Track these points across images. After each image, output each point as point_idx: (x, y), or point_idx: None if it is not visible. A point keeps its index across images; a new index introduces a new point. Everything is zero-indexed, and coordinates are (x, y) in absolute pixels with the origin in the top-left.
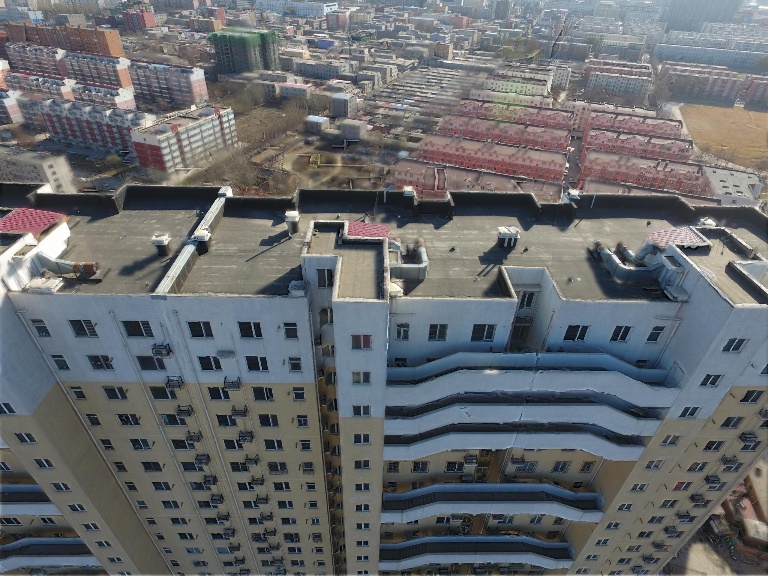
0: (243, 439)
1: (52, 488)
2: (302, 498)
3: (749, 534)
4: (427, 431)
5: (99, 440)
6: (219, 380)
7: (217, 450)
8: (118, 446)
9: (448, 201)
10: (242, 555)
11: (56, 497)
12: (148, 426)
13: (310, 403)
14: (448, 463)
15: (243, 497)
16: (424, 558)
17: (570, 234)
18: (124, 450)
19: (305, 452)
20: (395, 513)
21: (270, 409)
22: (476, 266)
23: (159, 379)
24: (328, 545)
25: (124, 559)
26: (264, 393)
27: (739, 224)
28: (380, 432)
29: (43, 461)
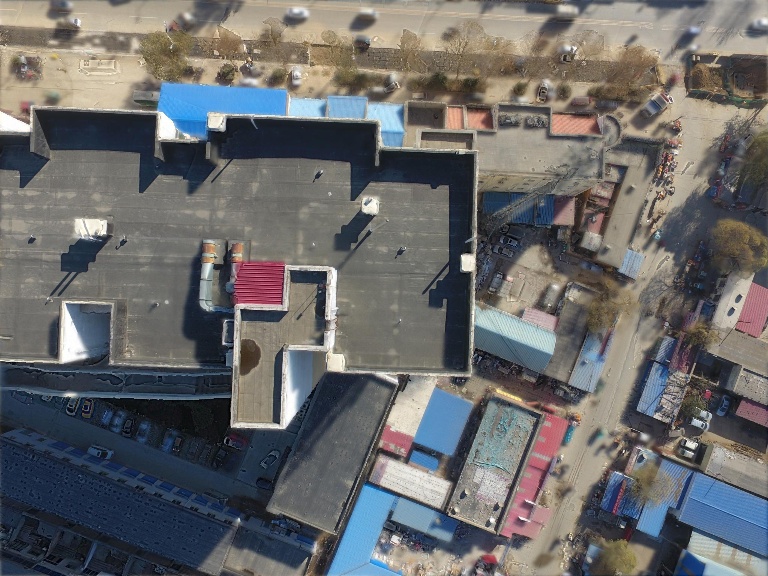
0: None
1: None
2: None
3: (581, 245)
4: None
5: None
6: None
7: None
8: None
9: (28, 137)
10: None
11: None
12: None
13: None
14: None
15: None
16: None
17: (197, 201)
18: None
19: None
20: None
21: None
22: (54, 275)
23: None
24: None
25: None
26: None
27: (449, 174)
28: None
29: None
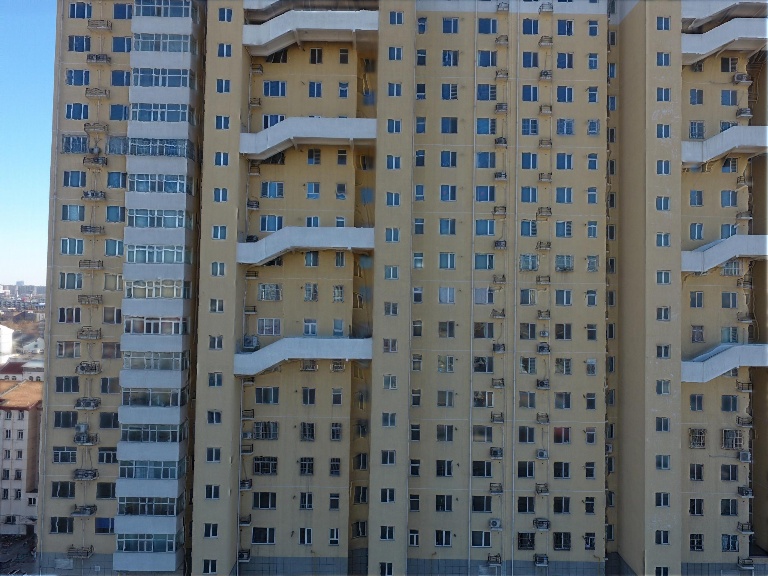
0: (545, 74)
1: (386, 90)
2: (583, 180)
3: None
4: (715, 15)
5: (416, 85)
6: (534, 10)
7: (516, 98)
8: (431, 91)
9: None
10: (502, 306)
11: (384, 105)
12: (464, 65)
13: (602, 38)
14: (722, 125)
15: (524, 179)
16: (731, 241)
17: None
18: (433, 99)
19: (592, 103)
20: (695, 142)
21: (569, 44)
22: None
23: (489, 10)
24: (603, 284)
25: (404, 231)
26: (566, 28)
27: None
28: (678, 13)
29: (395, 51)
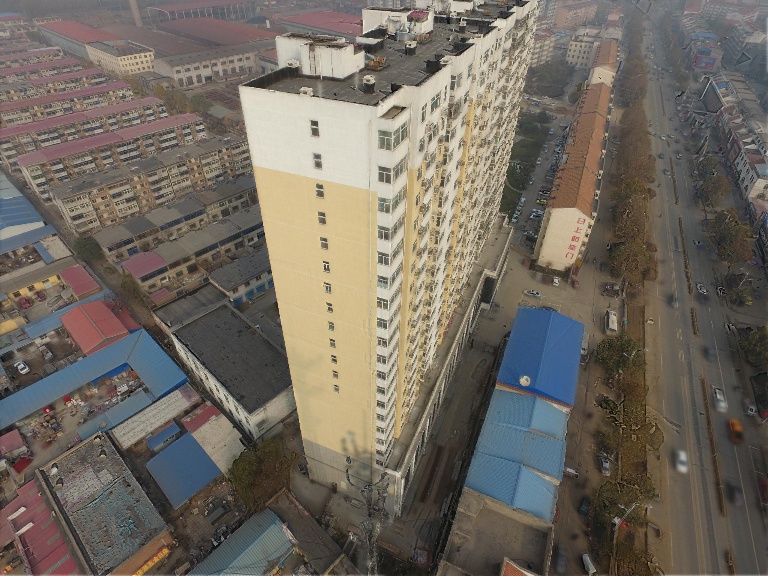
0: None
1: None
2: None
3: None
4: None
5: None
6: None
7: None
8: None
9: None
10: None
11: None
12: None
13: None
14: None
15: None
16: None
17: None
18: None
19: None
20: None
21: None
22: None
23: None
24: None
25: None
26: None
27: None
28: None
29: None
